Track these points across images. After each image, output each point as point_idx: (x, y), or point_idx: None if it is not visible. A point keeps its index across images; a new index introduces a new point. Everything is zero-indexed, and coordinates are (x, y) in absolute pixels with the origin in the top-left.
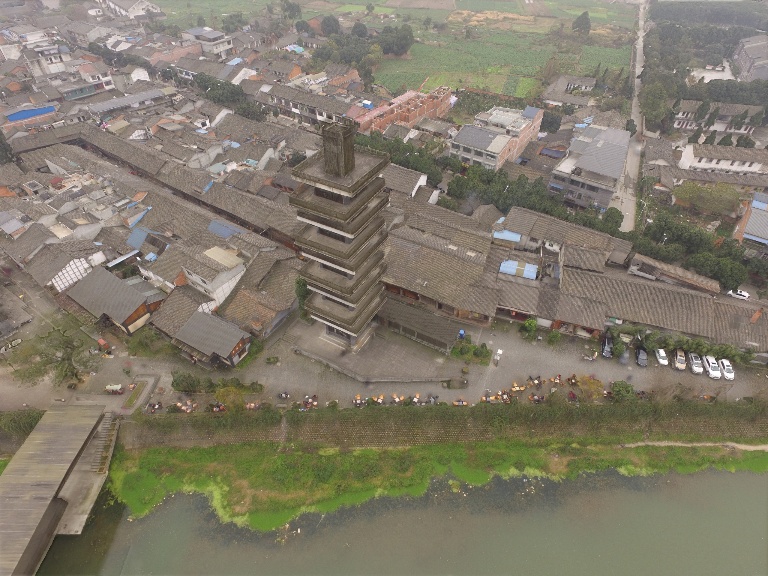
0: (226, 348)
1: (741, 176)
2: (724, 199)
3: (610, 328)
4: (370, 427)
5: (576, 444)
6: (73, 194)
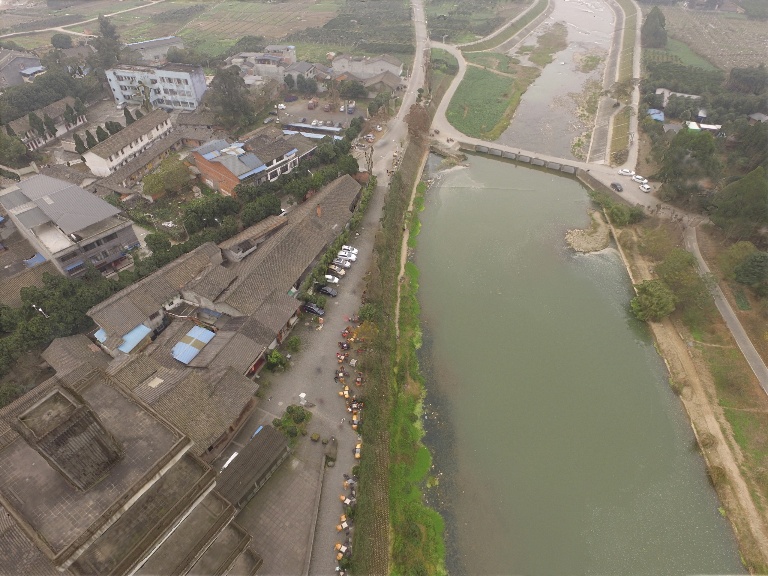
0: None
1: (150, 150)
2: (179, 170)
3: (300, 298)
4: (370, 571)
5: (394, 368)
6: None
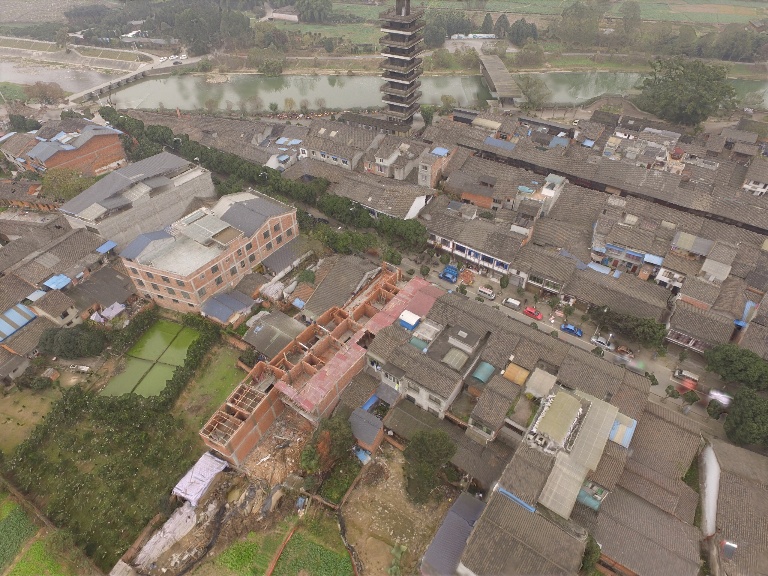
0: (460, 108)
1: None
2: None
3: None
4: None
5: None
6: (654, 153)
